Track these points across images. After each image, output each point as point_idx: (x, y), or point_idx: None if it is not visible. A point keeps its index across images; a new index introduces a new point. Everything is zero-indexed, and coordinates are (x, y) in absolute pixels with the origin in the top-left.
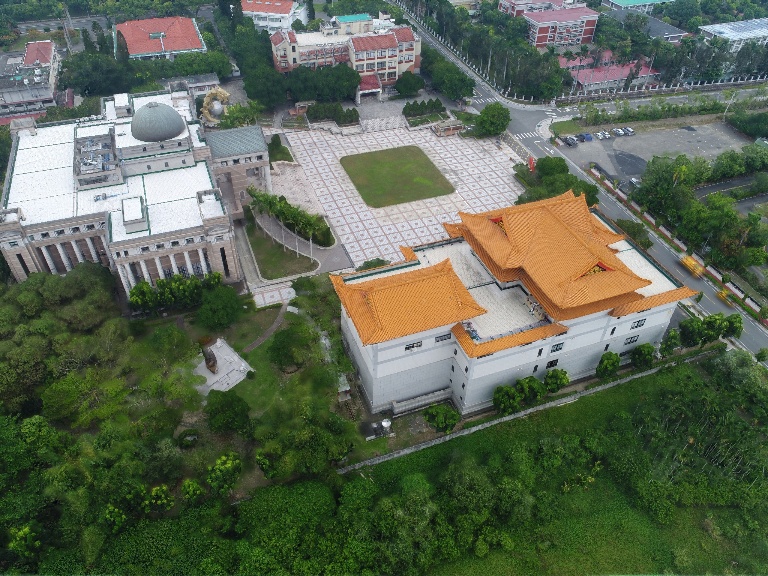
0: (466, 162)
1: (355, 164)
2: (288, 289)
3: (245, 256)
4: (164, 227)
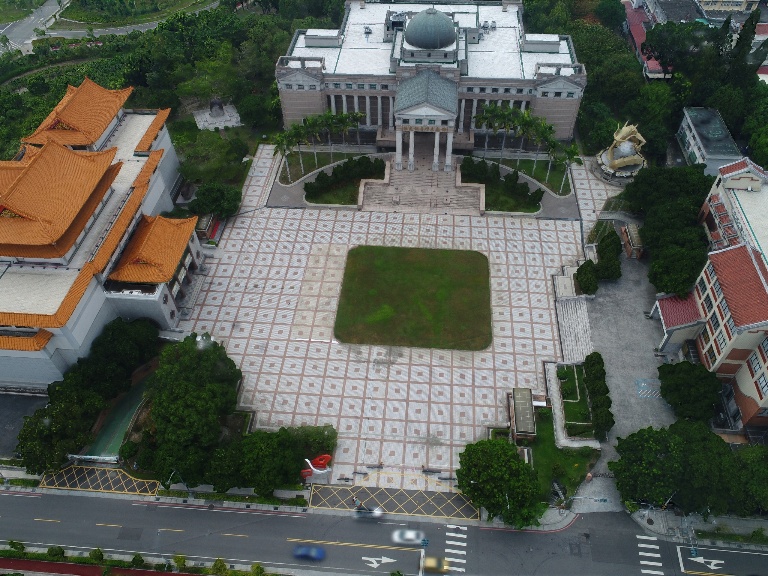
0: (406, 392)
1: (461, 262)
2: (269, 163)
3: (332, 149)
4: (303, 52)
